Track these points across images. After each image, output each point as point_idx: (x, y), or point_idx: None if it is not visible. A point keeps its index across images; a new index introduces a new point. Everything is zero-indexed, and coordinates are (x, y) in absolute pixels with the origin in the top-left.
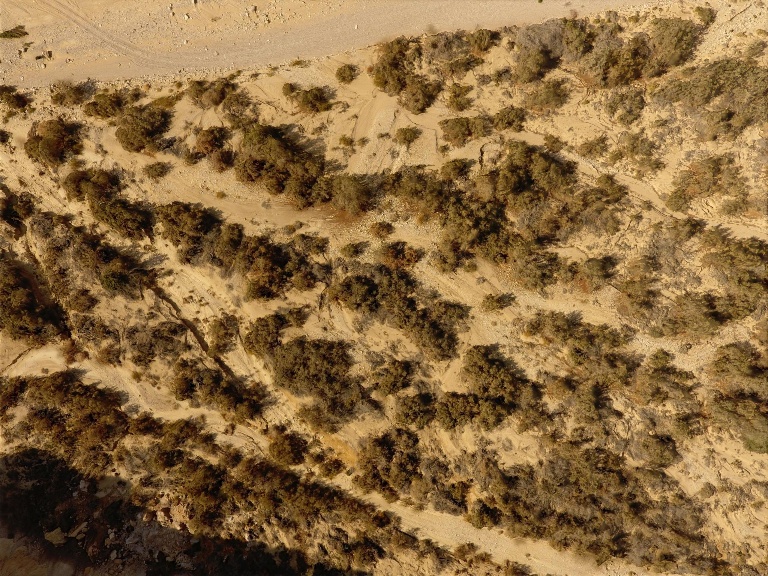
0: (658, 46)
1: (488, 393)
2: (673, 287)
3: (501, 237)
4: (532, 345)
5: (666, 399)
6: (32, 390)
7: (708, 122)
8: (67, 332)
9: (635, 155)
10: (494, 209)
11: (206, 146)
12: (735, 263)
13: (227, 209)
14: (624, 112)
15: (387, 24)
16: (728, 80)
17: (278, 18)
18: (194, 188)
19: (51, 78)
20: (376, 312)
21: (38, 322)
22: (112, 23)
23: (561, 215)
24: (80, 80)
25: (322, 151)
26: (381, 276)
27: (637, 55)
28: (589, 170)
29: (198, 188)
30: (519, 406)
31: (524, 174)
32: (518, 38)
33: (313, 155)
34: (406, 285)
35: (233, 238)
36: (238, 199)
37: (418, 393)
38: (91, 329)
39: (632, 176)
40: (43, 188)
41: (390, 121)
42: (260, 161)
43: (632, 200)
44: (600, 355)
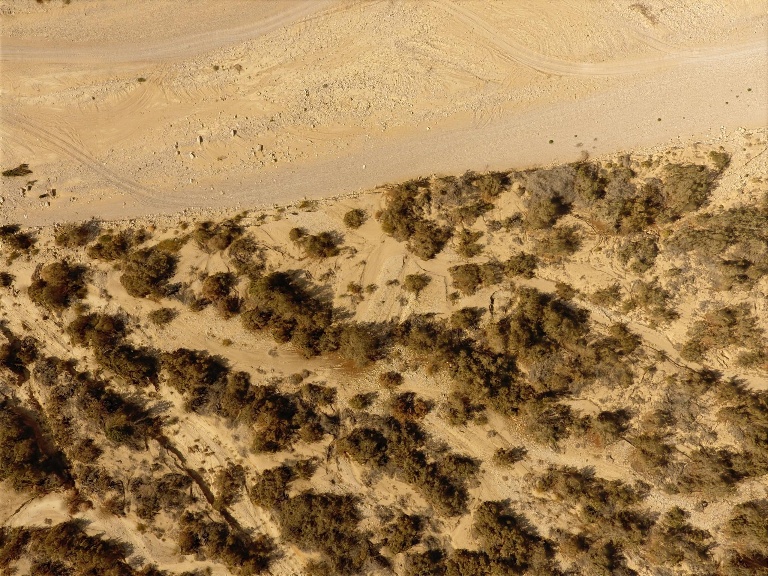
0: (672, 194)
1: (500, 555)
2: (688, 442)
3: (512, 390)
4: (544, 501)
5: (682, 560)
6: (35, 543)
7: (723, 273)
8: (71, 481)
9: (649, 305)
10: (505, 363)
11: (212, 295)
12: (752, 419)
13: (233, 357)
14: (637, 261)
15: (395, 164)
16: (744, 232)
17: (285, 157)
18: (200, 335)
19: (55, 217)
20: (385, 466)
21: (41, 475)
22: (117, 161)
23: (573, 367)
24: (84, 219)
25: (330, 298)
26: (390, 430)
27: (650, 202)
28: (602, 318)
29: (204, 335)
30: (531, 565)
31: (536, 327)
32: (529, 184)
33: (320, 302)
34: (415, 440)
35: (239, 389)
36: (244, 347)
37: (428, 550)
38: (95, 481)
39: (646, 325)
40: (47, 332)
41: (399, 267)
42: (267, 313)
43: (646, 350)
44: (614, 513)
